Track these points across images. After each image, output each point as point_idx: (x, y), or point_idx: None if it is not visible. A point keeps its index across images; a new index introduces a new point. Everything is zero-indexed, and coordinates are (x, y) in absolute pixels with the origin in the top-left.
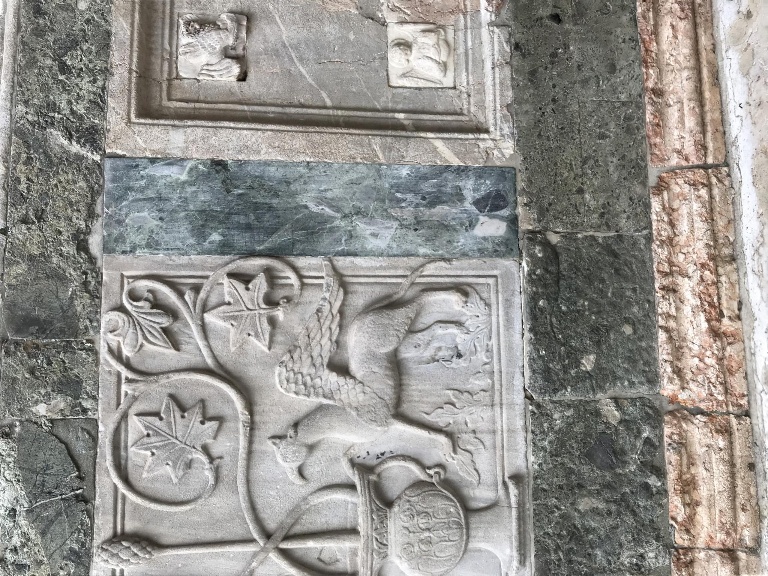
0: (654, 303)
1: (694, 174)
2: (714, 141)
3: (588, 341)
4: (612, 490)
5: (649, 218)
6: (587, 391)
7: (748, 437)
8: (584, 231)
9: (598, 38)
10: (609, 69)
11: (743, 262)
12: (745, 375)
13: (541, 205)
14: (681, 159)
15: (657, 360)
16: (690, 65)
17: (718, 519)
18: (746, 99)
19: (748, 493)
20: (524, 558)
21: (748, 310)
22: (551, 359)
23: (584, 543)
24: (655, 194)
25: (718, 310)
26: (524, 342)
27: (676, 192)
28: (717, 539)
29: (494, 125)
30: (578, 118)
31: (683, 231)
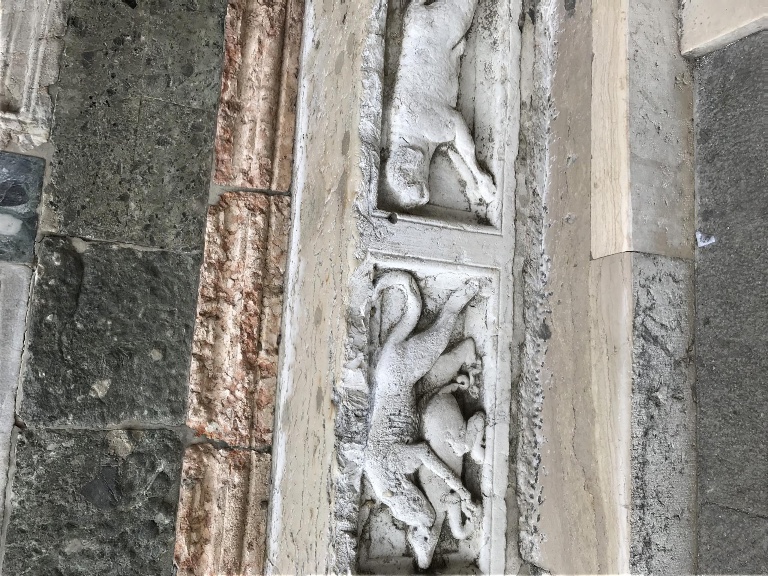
0: (193, 329)
1: (255, 198)
2: (280, 168)
3: (104, 365)
4: (108, 530)
5: (203, 238)
6: (94, 420)
7: (266, 474)
8: (122, 242)
9: (180, 34)
10: (185, 71)
11: (286, 296)
12: (273, 411)
13: (71, 206)
14: (245, 181)
15: (187, 390)
16: (268, 85)
17: (221, 559)
18: (306, 131)
19: (256, 532)
20: None
21: (283, 345)
22: (52, 383)
23: None
24: (211, 213)
25: (256, 342)
26: (22, 361)
27: (236, 214)
28: None
29: (27, 105)
30: (137, 117)
31: (235, 256)
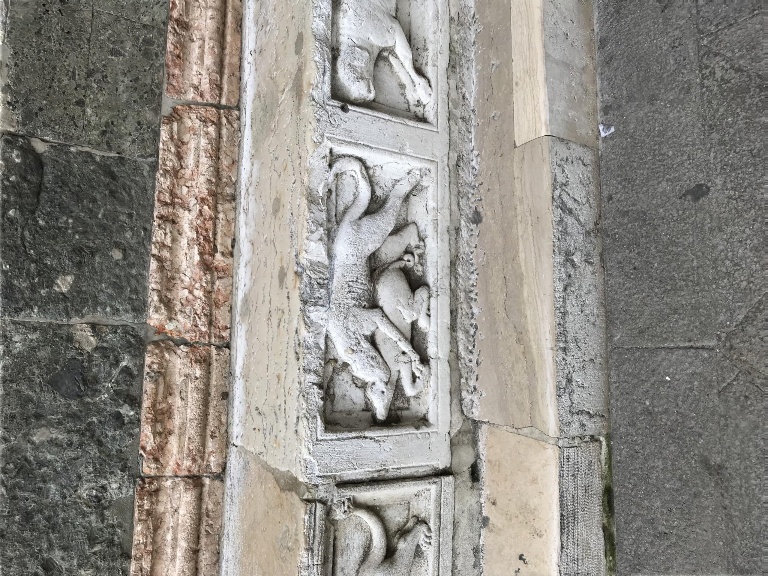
0: (151, 232)
1: (206, 111)
2: (229, 84)
3: (67, 261)
4: (75, 419)
5: (157, 146)
6: (59, 313)
7: (225, 367)
8: (79, 146)
9: None
10: None
11: (239, 201)
12: (230, 309)
13: (29, 108)
14: (196, 95)
15: (146, 289)
16: (215, 6)
17: (186, 446)
18: (254, 47)
19: (218, 420)
20: None
21: (238, 247)
22: (16, 275)
23: (35, 476)
24: (164, 123)
25: (212, 245)
26: None
27: (188, 126)
28: (183, 466)
29: None
30: (90, 27)
31: (189, 165)
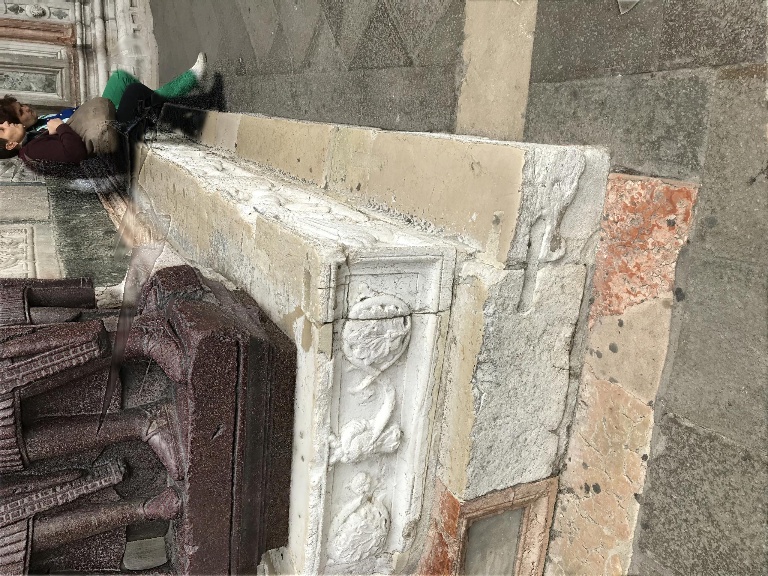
0: None
1: None
2: None
3: None
4: None
5: None
6: None
7: None
8: None
9: None
10: None
11: None
12: None
13: None
14: None
15: None
16: None
17: None
18: None
19: None
20: (41, 172)
21: None
22: None
23: None
24: None
25: None
26: None
27: None
28: None
29: None
30: None
31: None
